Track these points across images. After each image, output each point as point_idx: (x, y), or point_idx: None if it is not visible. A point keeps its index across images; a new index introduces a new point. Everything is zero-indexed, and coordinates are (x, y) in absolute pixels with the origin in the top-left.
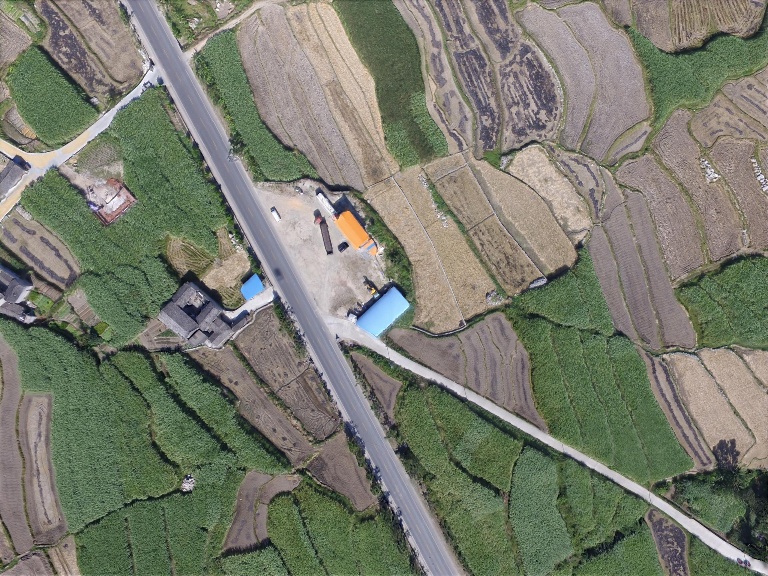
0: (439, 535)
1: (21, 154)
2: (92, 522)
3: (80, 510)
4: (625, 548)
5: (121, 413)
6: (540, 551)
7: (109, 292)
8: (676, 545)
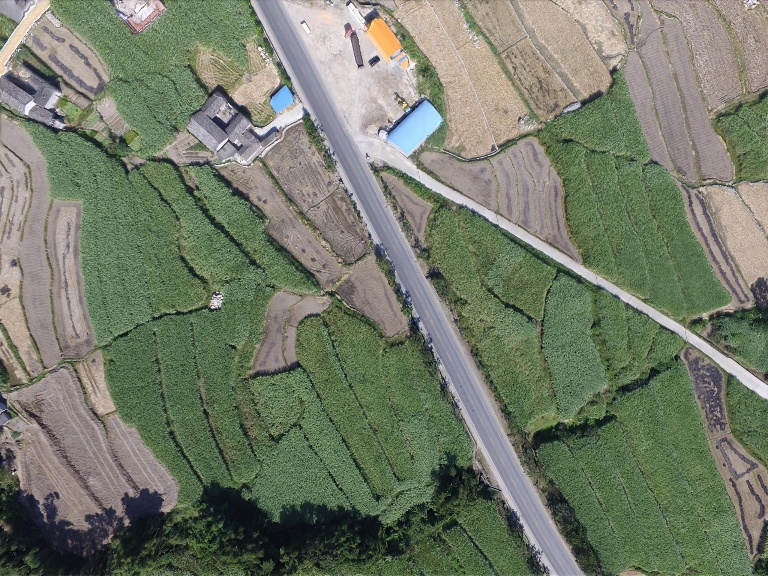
0: (470, 364)
1: None
2: (120, 335)
3: (108, 321)
4: (661, 383)
5: (150, 223)
6: (574, 382)
7: (138, 99)
8: (713, 385)
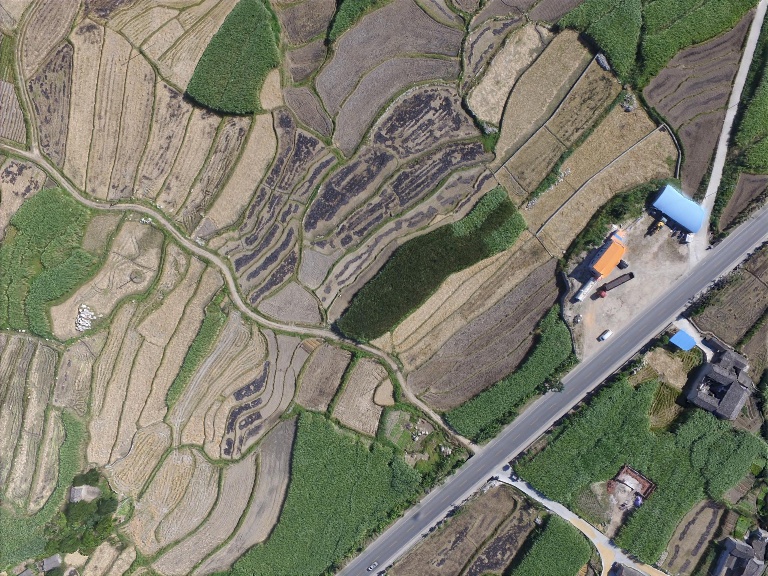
0: None
1: (606, 573)
2: None
3: None
4: None
5: None
6: None
7: None
8: None
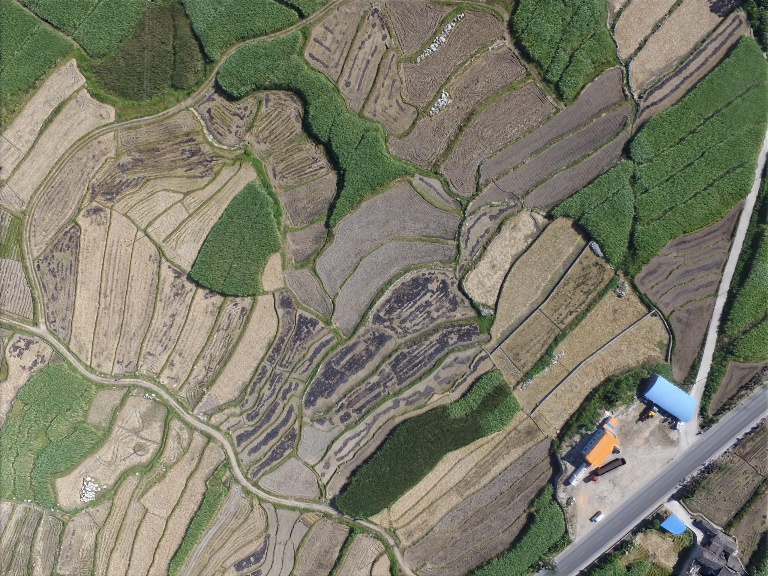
0: None
1: None
2: None
3: None
4: None
5: None
6: None
7: None
8: None
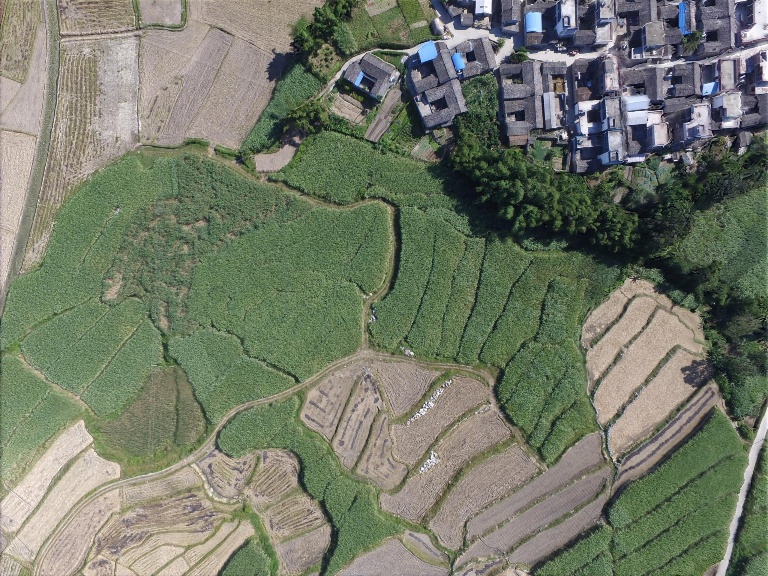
0: None
1: None
2: None
3: None
4: None
5: None
6: None
7: None
8: None
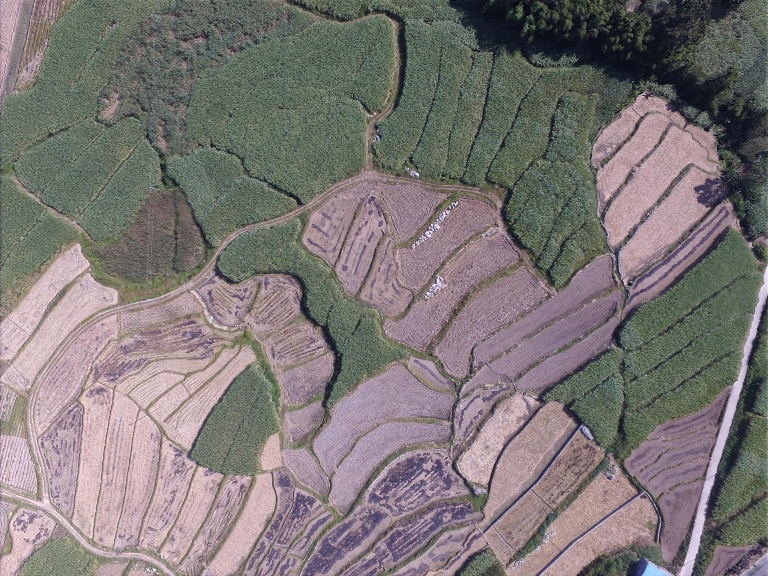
0: None
1: None
2: None
3: None
4: None
5: None
6: None
7: None
8: None
